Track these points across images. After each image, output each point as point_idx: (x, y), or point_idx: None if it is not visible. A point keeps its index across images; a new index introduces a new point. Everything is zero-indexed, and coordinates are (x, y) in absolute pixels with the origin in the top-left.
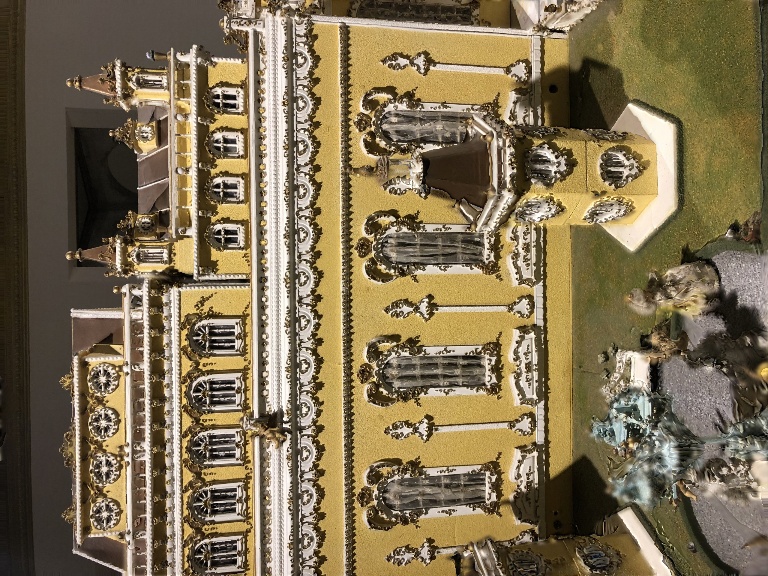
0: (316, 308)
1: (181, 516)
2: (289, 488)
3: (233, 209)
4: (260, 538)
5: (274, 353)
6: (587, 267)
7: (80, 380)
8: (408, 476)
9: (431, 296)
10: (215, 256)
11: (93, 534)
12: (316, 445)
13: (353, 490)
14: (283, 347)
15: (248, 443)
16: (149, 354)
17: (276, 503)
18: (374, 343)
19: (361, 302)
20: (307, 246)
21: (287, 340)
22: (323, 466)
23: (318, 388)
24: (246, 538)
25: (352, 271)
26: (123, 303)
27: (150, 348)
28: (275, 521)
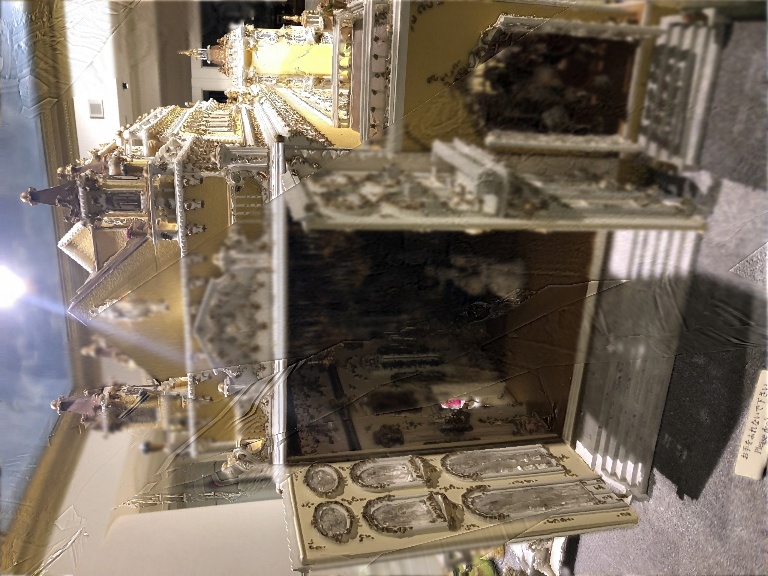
0: None
1: None
2: None
3: None
4: None
5: None
6: None
7: None
8: None
9: None
10: None
11: None
12: None
13: None
14: None
15: (237, 122)
16: None
17: None
18: None
19: None
20: None
21: None
22: None
23: None
24: None
25: None
26: None
27: None
28: None
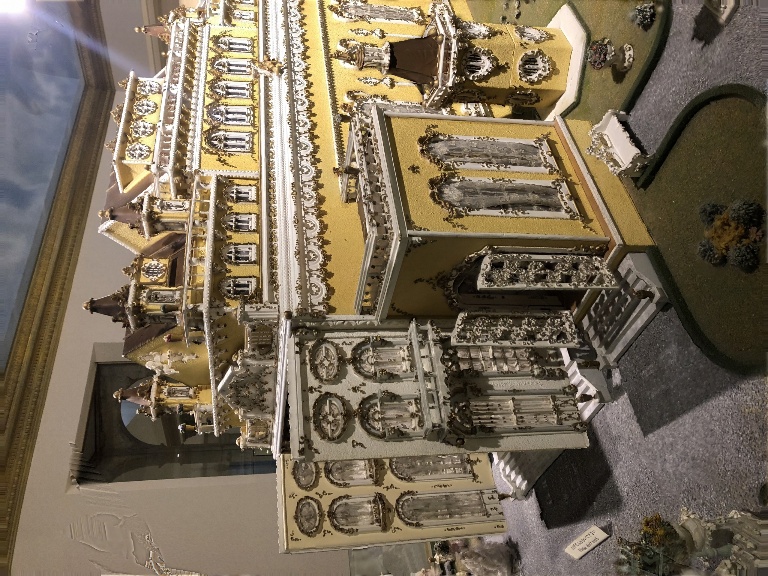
0: (303, 27)
1: (202, 119)
2: (287, 92)
3: (247, 8)
4: (264, 121)
5: (274, 40)
6: (484, 9)
7: (132, 85)
8: (380, 102)
9: (382, 30)
10: (234, 22)
11: (126, 161)
12: (306, 80)
13: (337, 105)
14: (280, 37)
15: (255, 91)
16: (187, 45)
17: (277, 102)
18: (344, 39)
19: (333, 28)
20: (295, 4)
21: (283, 32)
22: (313, 92)
23: (306, 56)
24: (253, 137)
25: (326, 16)
26: (171, 30)
27: (187, 44)
28: (276, 110)
